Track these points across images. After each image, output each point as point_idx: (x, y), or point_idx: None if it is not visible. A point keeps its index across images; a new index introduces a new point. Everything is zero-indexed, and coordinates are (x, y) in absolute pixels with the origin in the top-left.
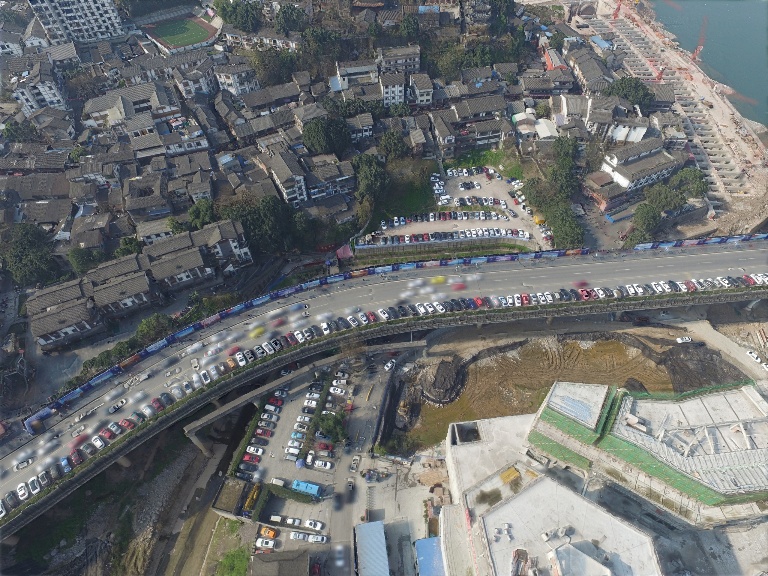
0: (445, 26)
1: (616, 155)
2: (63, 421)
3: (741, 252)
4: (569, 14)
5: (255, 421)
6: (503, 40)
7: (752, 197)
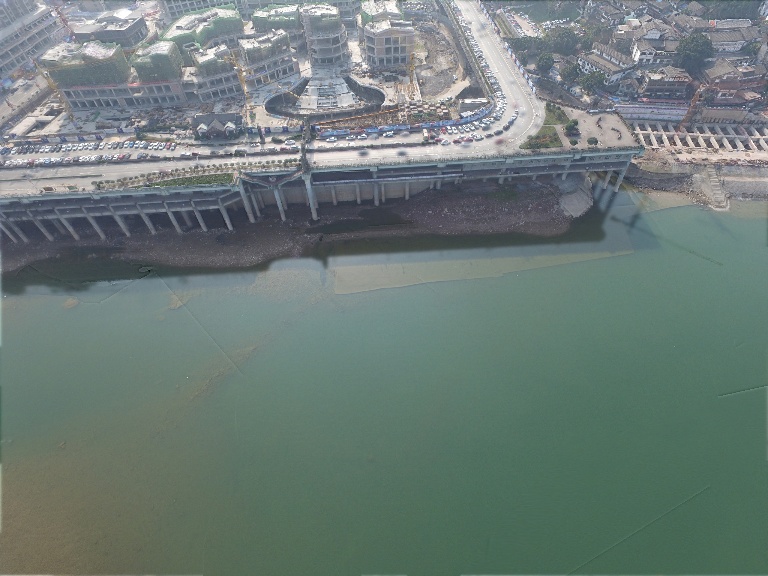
0: None
1: (599, 44)
2: None
3: (513, 74)
4: None
5: None
6: None
7: None
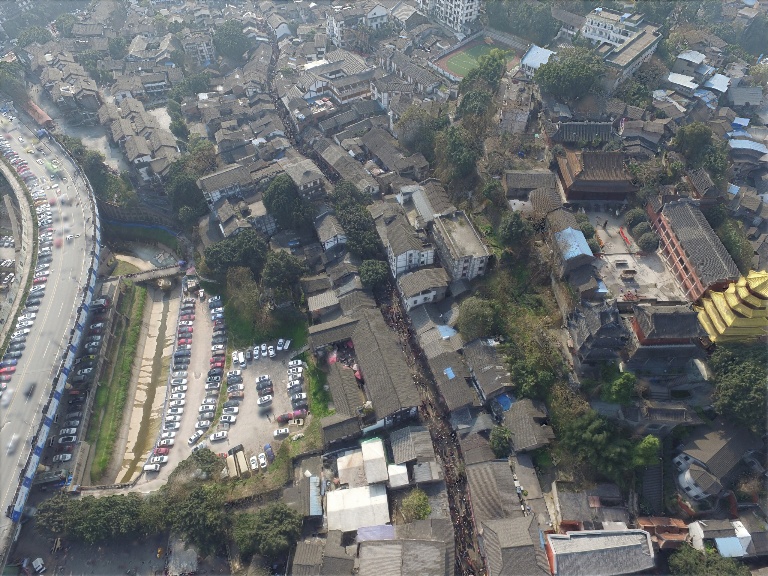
0: None
1: None
2: (43, 144)
3: None
4: None
5: (8, 233)
6: (558, 394)
7: None
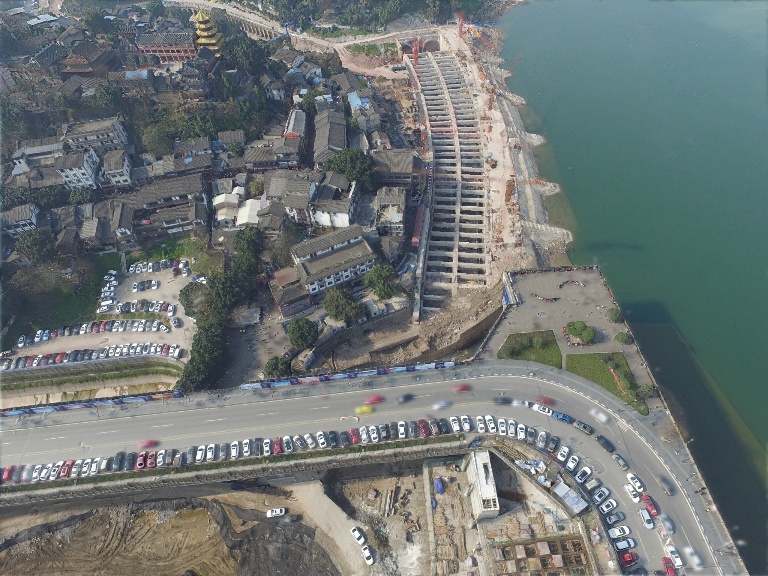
0: (162, 92)
1: (296, 251)
2: None
3: (371, 391)
4: (401, 52)
5: None
6: (221, 107)
7: (481, 289)
